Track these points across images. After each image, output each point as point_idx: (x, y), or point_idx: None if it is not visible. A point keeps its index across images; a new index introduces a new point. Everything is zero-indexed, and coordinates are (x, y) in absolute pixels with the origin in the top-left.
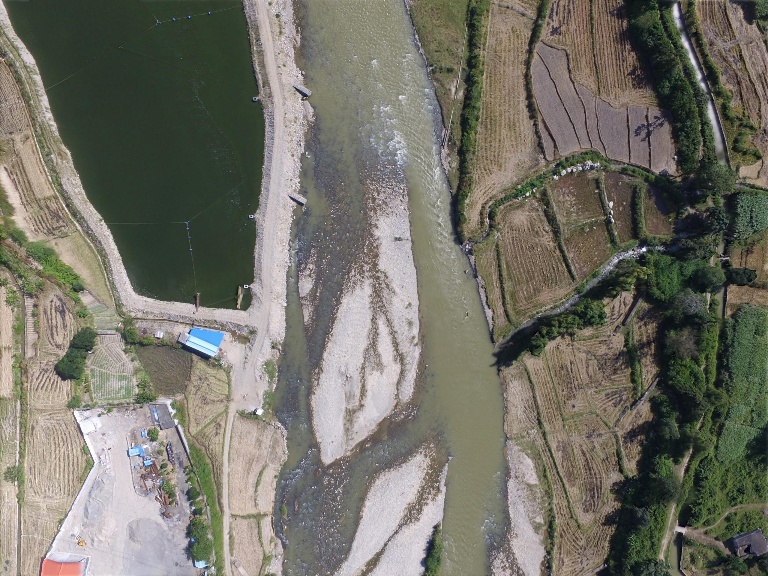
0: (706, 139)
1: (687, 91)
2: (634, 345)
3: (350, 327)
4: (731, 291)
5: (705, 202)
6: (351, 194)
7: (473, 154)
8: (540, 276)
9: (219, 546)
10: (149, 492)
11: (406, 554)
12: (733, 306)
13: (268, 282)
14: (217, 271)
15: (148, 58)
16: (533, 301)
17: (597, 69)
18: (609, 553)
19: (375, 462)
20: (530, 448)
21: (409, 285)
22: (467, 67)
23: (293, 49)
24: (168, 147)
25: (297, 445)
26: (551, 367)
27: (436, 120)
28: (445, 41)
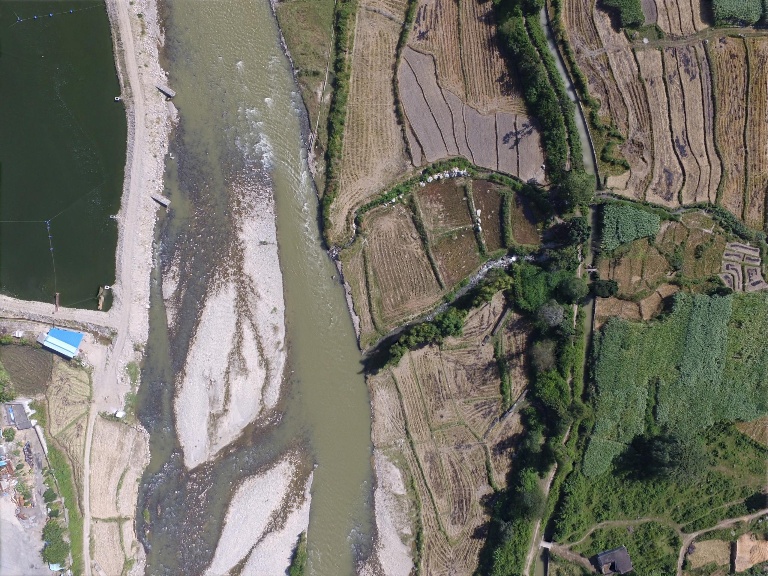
0: (572, 148)
1: (551, 99)
2: (503, 356)
3: (214, 331)
4: (599, 303)
5: (572, 212)
6: (216, 196)
7: (338, 159)
8: (408, 283)
9: (77, 549)
10: (4, 493)
11: (270, 562)
12: (601, 318)
13: (128, 283)
14: (78, 271)
15: (9, 56)
16: (400, 309)
17: (464, 75)
18: (478, 567)
19: (239, 468)
20: (397, 458)
21: (274, 290)
22: (334, 71)
23: (157, 49)
24: (29, 145)
25: (160, 449)
26: (419, 376)
27: (303, 123)
28: (311, 44)
